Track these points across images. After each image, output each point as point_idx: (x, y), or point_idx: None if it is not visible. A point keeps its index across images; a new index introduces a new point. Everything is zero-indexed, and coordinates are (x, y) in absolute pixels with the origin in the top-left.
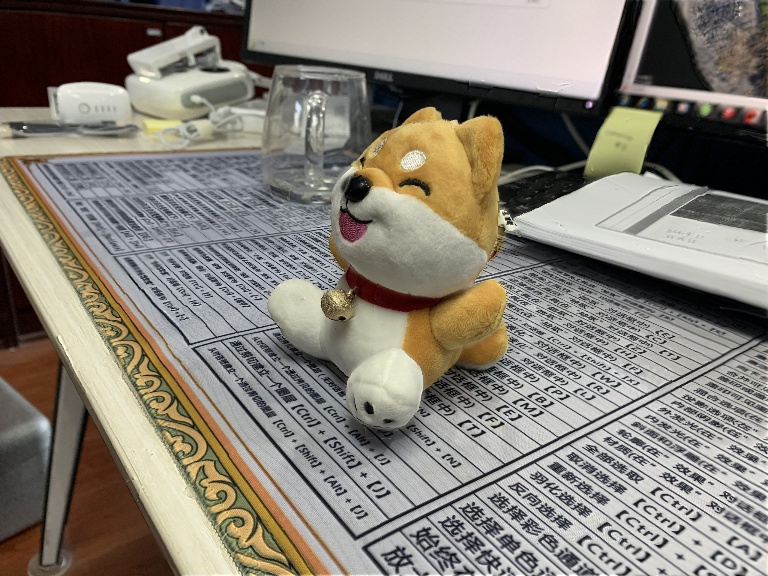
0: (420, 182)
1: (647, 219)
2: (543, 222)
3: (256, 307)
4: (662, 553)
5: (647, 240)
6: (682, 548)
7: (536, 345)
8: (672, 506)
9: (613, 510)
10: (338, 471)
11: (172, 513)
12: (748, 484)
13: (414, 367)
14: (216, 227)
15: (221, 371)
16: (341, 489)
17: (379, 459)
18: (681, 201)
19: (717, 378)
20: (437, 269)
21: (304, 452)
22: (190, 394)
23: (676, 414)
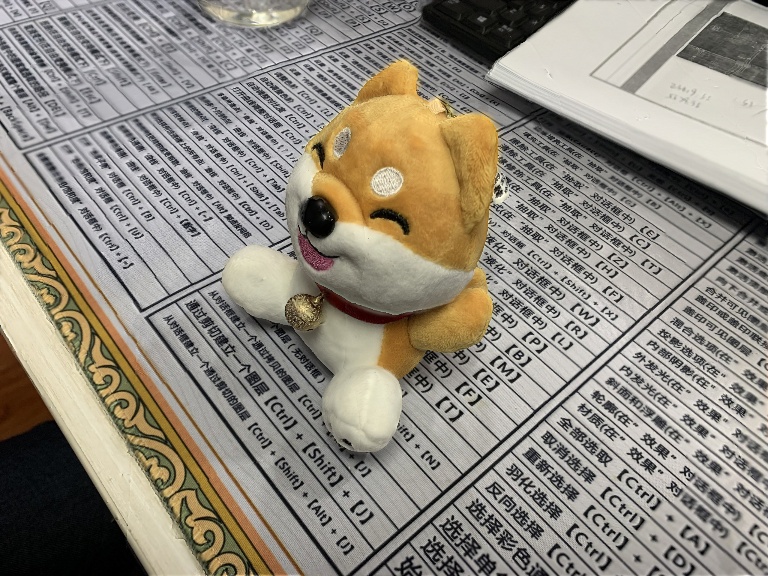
0: (396, 215)
1: (650, 63)
2: (530, 71)
3: (207, 235)
4: (622, 556)
5: (647, 102)
6: (640, 547)
7: (515, 267)
8: (635, 493)
9: (581, 506)
10: (321, 492)
11: (164, 560)
12: (707, 454)
13: (393, 395)
14: (139, 80)
15: (183, 354)
16: (326, 517)
17: (360, 469)
18: (692, 29)
19: (695, 299)
20: (417, 304)
21: (284, 469)
22: (155, 393)
23: (650, 361)
